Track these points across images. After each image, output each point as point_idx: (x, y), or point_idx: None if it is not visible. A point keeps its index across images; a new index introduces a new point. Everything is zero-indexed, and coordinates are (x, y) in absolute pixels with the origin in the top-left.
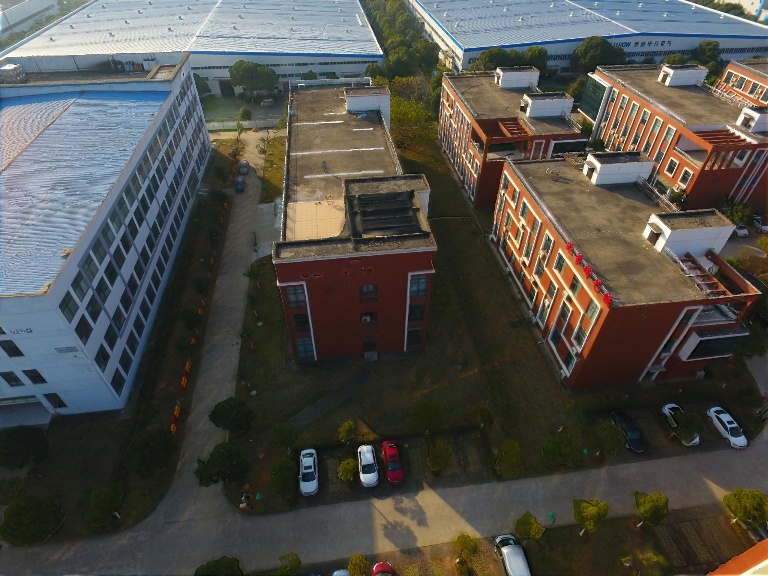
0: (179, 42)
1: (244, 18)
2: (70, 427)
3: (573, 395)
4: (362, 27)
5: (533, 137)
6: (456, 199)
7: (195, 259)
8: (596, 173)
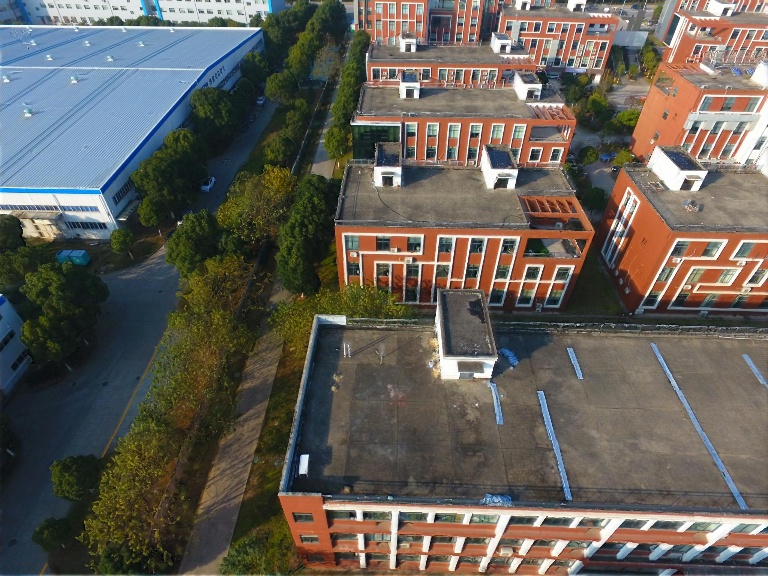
0: None
1: None
2: None
3: None
4: None
5: None
6: None
7: None
8: (700, 181)
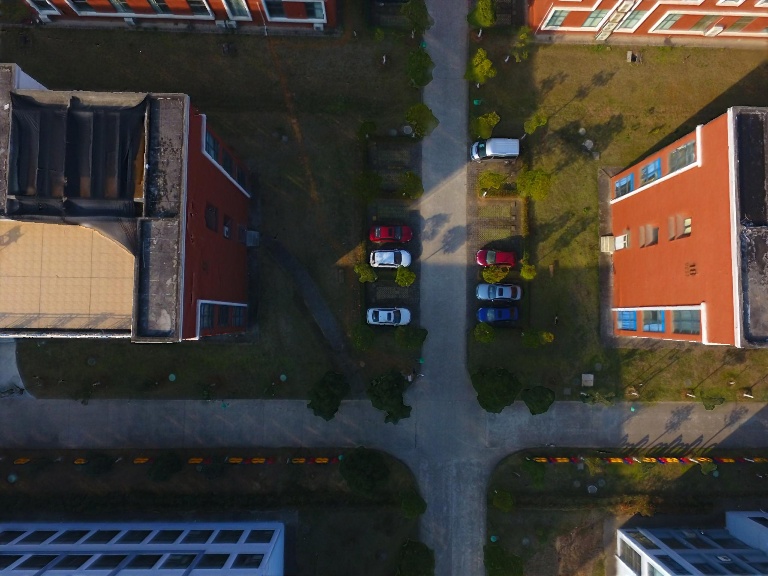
0: None
1: None
2: (299, 575)
3: (344, 29)
4: None
5: None
6: None
7: (8, 490)
8: None
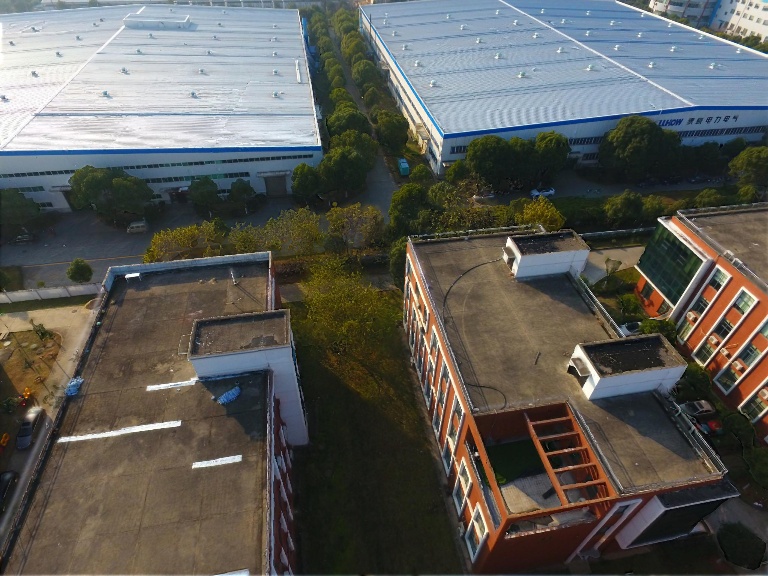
0: (1, 127)
1: (130, 73)
2: None
3: None
4: (300, 85)
5: (616, 499)
6: (436, 538)
7: None
8: None
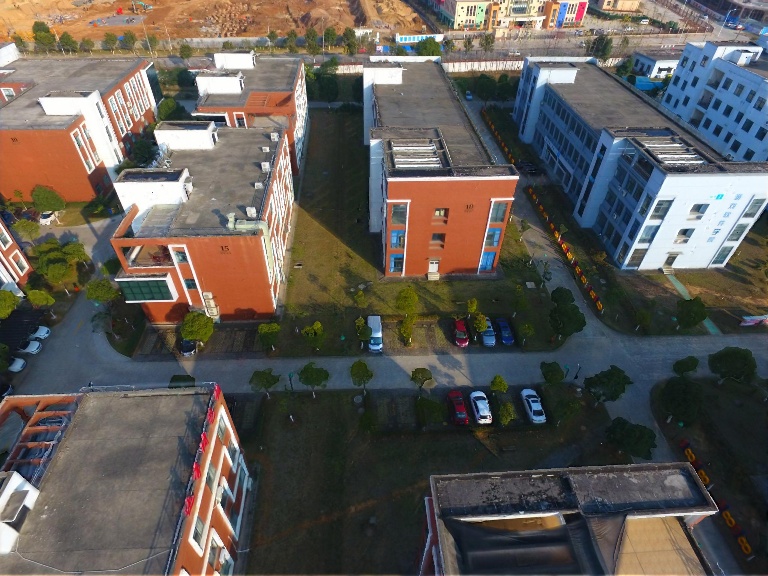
0: None
1: None
2: None
3: (252, 461)
4: None
5: None
6: None
7: None
8: None
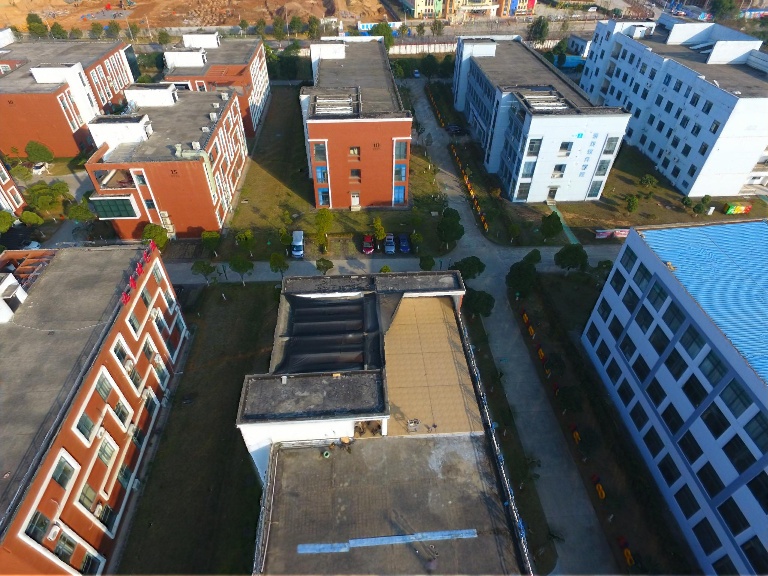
0: None
1: None
2: None
3: (191, 323)
4: None
5: None
6: None
7: None
8: None
